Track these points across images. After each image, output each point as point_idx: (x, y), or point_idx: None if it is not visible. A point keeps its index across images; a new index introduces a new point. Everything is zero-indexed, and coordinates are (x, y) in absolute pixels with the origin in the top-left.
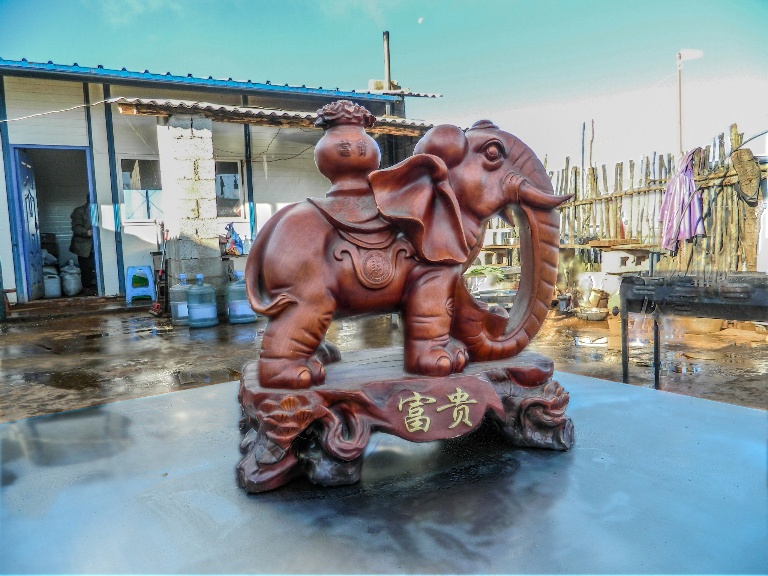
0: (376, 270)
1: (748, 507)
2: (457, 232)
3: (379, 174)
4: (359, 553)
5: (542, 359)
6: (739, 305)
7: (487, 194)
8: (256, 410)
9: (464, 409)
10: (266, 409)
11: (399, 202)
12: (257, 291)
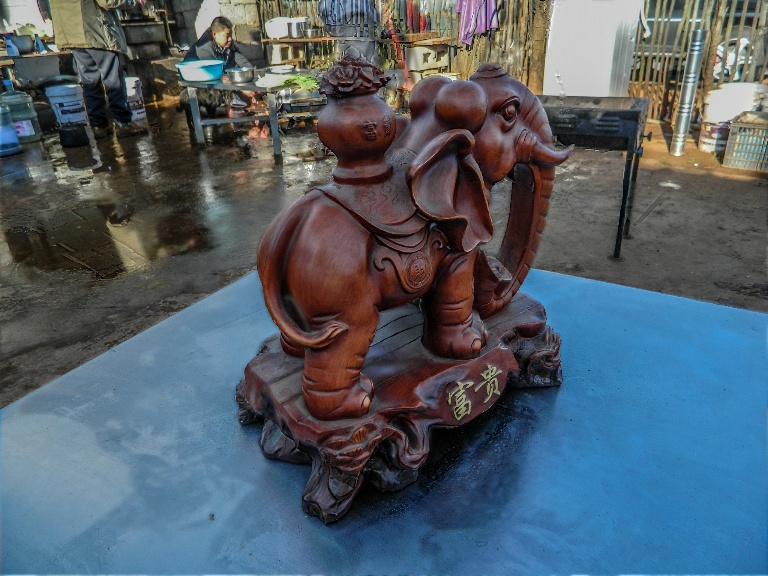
0: (420, 274)
1: (721, 428)
2: (481, 209)
3: None
4: (488, 575)
5: (534, 305)
6: (566, 134)
7: (504, 159)
8: (318, 445)
9: (494, 382)
10: (335, 446)
11: (428, 187)
12: (285, 313)
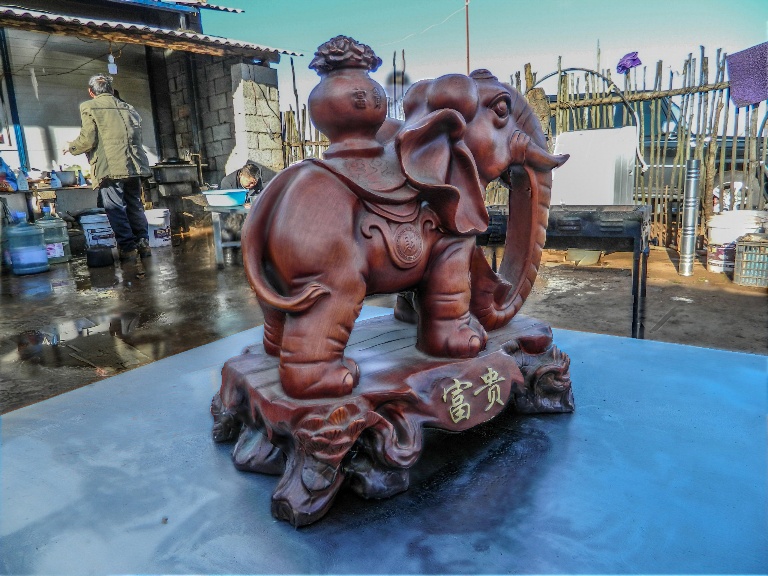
0: (410, 247)
1: (760, 448)
2: (475, 198)
3: (410, 133)
4: None
5: (538, 323)
6: (572, 236)
7: (498, 154)
8: (293, 428)
9: (496, 388)
10: (311, 426)
11: (419, 165)
12: (264, 279)
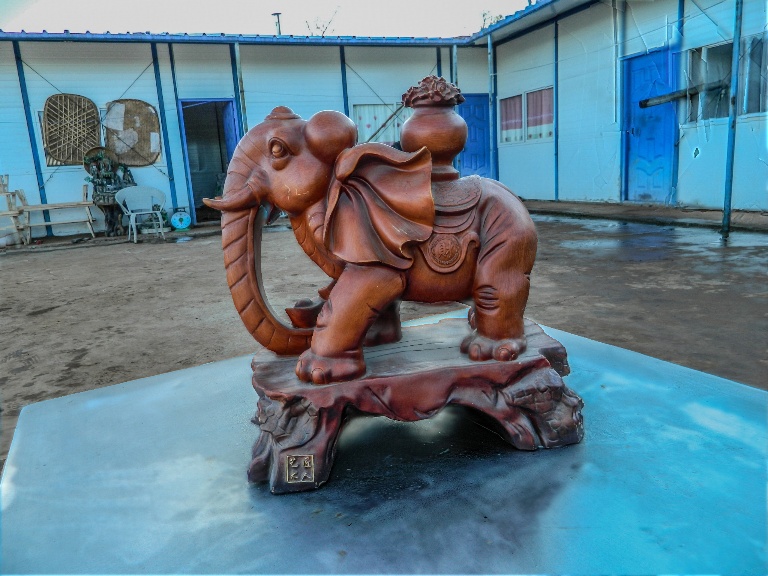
0: None
1: None
2: None
3: None
4: None
5: None
6: None
7: None
8: None
9: None
10: None
11: None
12: None
